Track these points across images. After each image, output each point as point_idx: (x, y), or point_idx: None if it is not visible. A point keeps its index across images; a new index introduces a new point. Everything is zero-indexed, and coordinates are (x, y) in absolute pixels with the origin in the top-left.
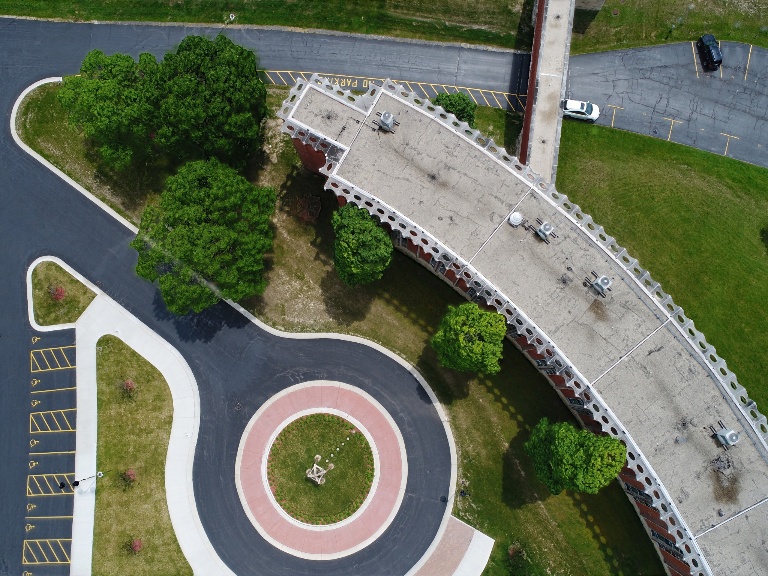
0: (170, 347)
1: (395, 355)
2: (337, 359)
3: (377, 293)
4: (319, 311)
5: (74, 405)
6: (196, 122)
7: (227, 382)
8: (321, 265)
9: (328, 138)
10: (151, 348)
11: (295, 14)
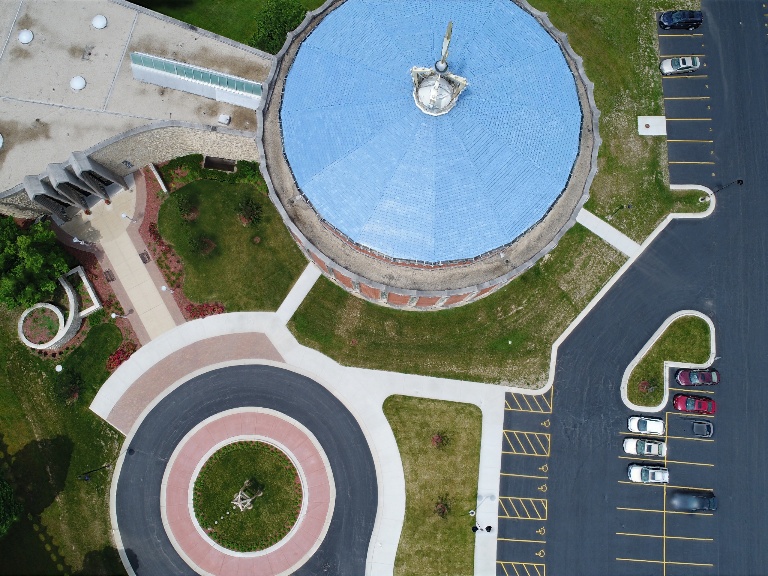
0: None
1: None
2: None
3: None
4: None
5: None
6: None
7: None
8: None
9: None
10: None
11: None
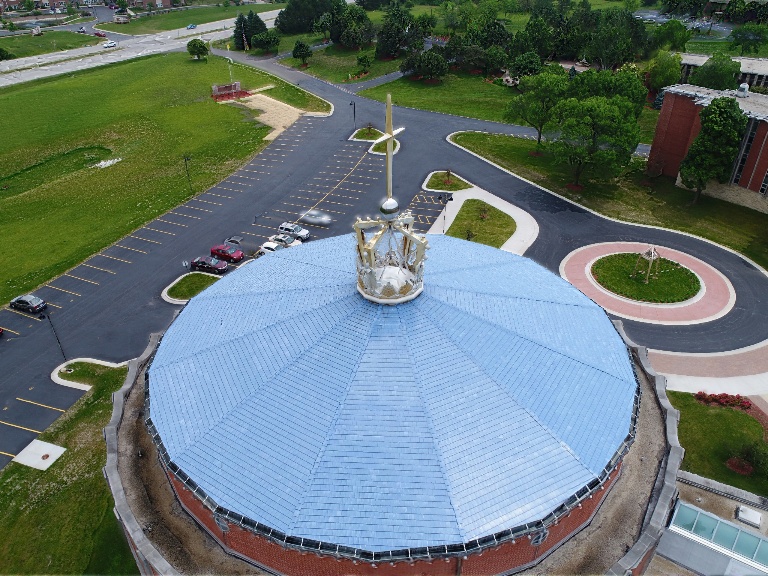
0: (522, 210)
1: (720, 245)
2: (664, 238)
3: (703, 217)
4: (650, 218)
5: (437, 216)
6: (607, 85)
7: (564, 230)
8: (654, 202)
9: (698, 94)
10: (507, 208)
11: (642, 140)
